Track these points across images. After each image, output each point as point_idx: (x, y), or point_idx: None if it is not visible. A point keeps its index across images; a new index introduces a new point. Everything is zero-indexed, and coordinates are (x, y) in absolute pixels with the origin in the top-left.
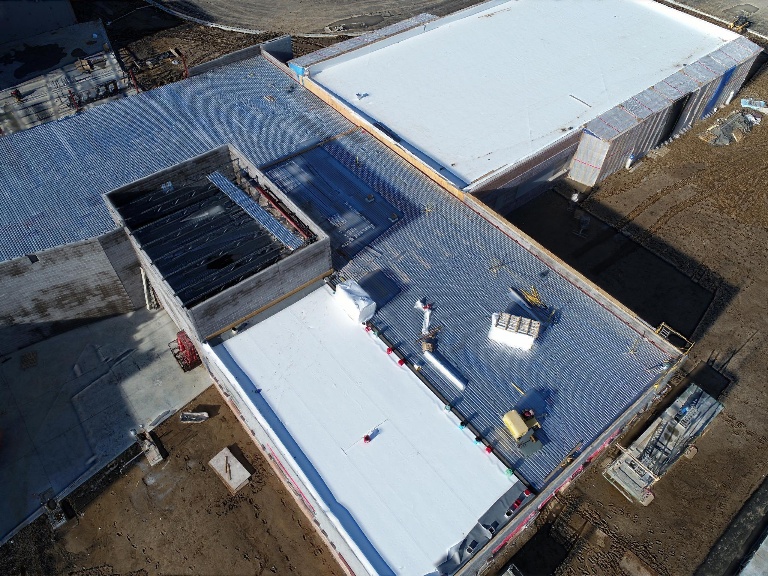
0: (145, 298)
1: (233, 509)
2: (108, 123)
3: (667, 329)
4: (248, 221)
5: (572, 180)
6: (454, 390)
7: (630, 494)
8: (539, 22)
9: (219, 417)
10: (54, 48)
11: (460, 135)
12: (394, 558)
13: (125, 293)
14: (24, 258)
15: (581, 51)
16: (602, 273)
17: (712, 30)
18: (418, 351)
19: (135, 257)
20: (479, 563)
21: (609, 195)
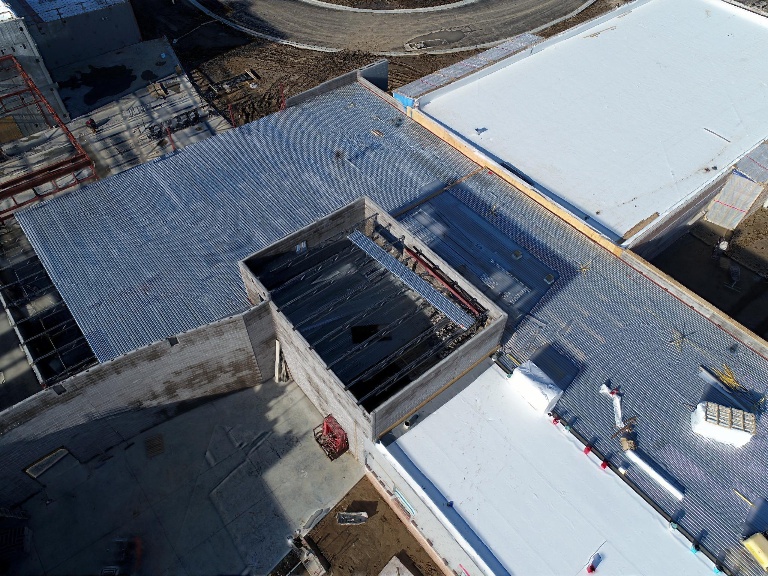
0: (275, 370)
1: None
2: (209, 164)
3: None
4: (404, 291)
5: (709, 222)
6: (671, 500)
7: None
8: (649, 43)
9: (378, 516)
10: (122, 70)
11: (597, 177)
12: None
13: (256, 367)
14: (164, 342)
15: (703, 76)
16: (766, 334)
17: None
18: (618, 449)
19: (273, 330)
20: None
21: (753, 240)
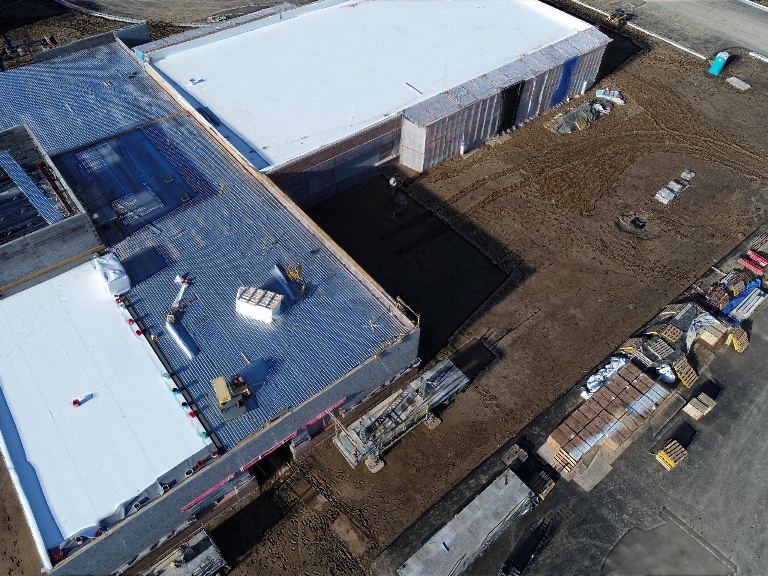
0: None
1: None
2: None
3: (400, 303)
4: (22, 198)
5: (404, 166)
6: (183, 359)
7: (350, 460)
8: (400, 12)
9: None
10: None
11: (282, 120)
12: (62, 512)
13: None
14: None
15: (432, 40)
16: (404, 254)
17: (569, 21)
18: (161, 322)
19: None
20: (158, 520)
21: (435, 180)
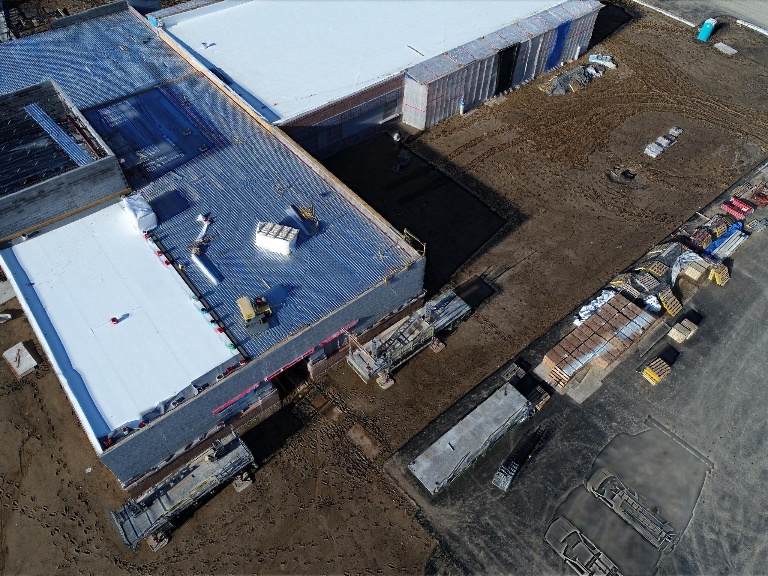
0: None
1: (15, 391)
2: None
3: (407, 234)
4: (53, 145)
5: (406, 124)
6: (209, 285)
7: (363, 376)
8: None
9: (22, 319)
10: None
11: (291, 79)
12: (107, 409)
13: None
14: None
15: (432, 7)
16: (408, 203)
17: None
18: (187, 255)
19: None
20: (193, 419)
21: (437, 137)
